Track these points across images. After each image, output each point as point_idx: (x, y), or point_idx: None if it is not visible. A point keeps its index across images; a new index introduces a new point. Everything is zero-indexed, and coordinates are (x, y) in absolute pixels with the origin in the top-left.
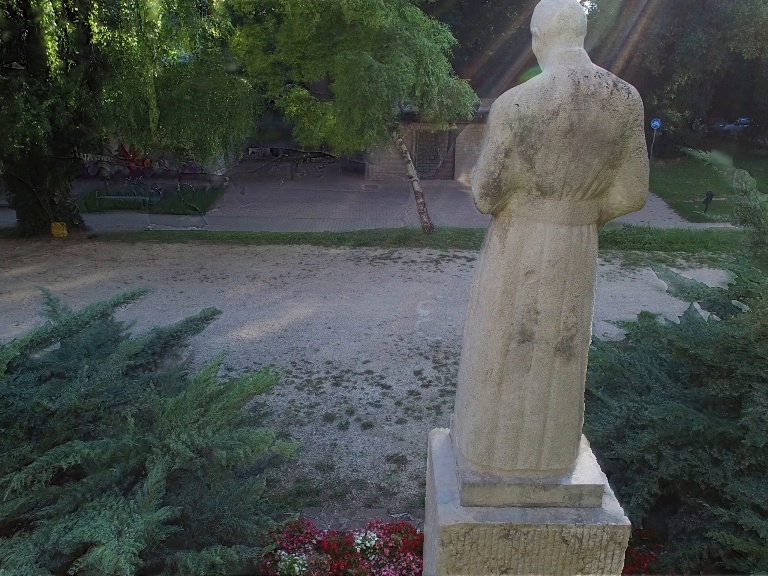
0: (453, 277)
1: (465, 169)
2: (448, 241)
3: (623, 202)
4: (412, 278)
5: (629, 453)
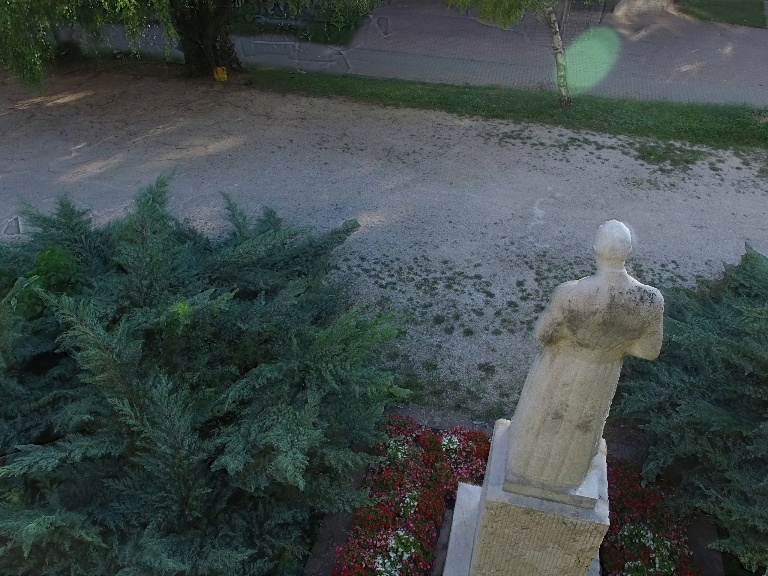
0: (577, 169)
1: (628, 1)
2: (583, 120)
3: (639, 355)
4: (536, 166)
5: (659, 430)
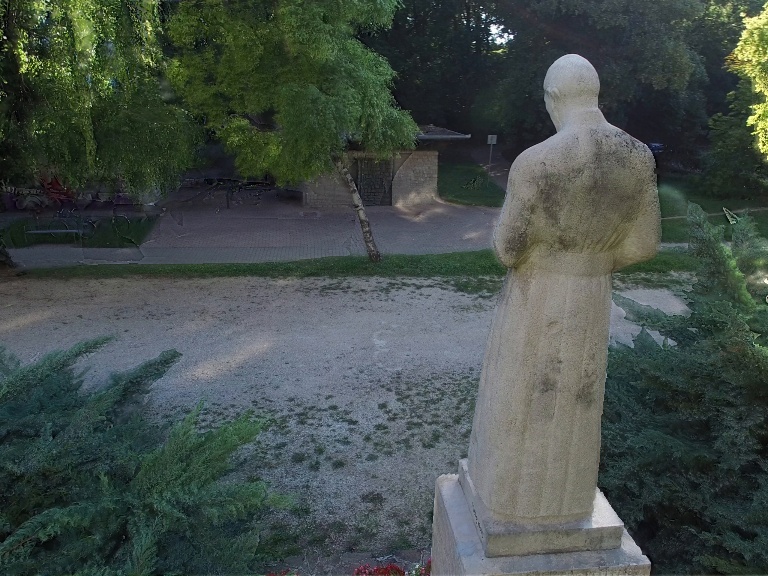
0: (405, 305)
1: (402, 195)
2: (395, 269)
3: (637, 253)
4: (364, 308)
5: (612, 482)
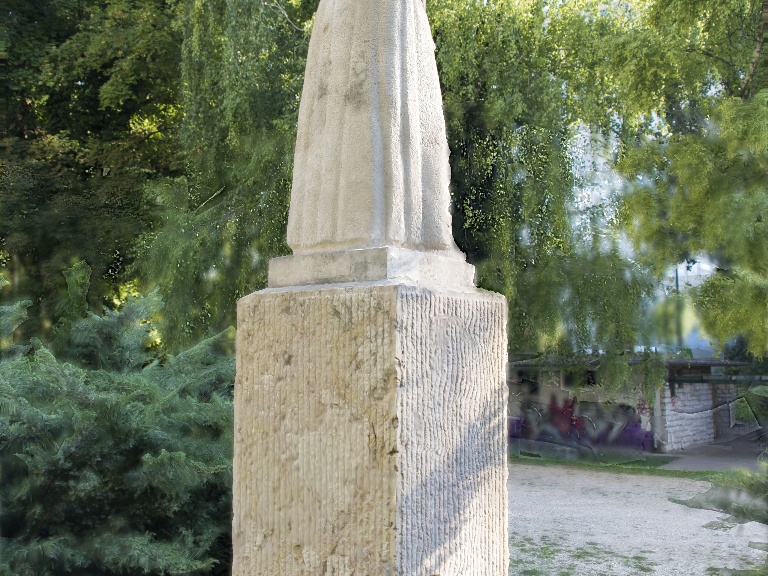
0: None
1: None
2: None
3: None
4: None
5: (747, 473)
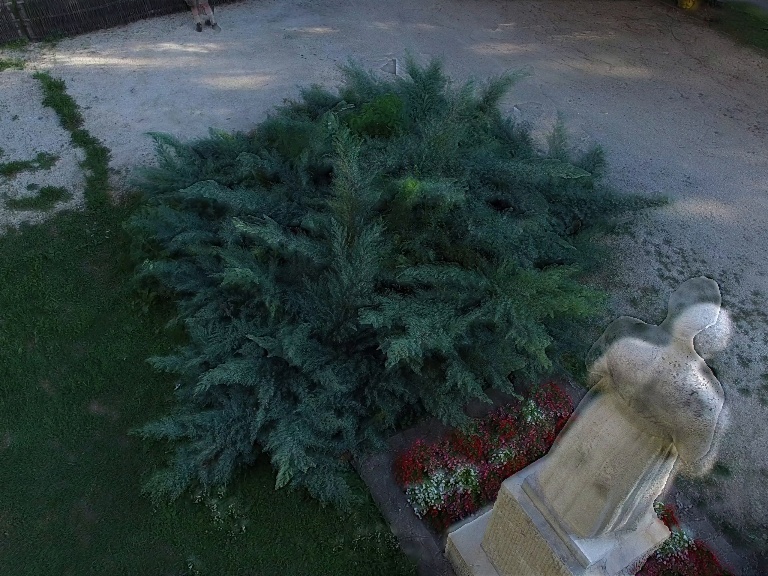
0: None
1: None
2: None
3: None
4: None
5: None
